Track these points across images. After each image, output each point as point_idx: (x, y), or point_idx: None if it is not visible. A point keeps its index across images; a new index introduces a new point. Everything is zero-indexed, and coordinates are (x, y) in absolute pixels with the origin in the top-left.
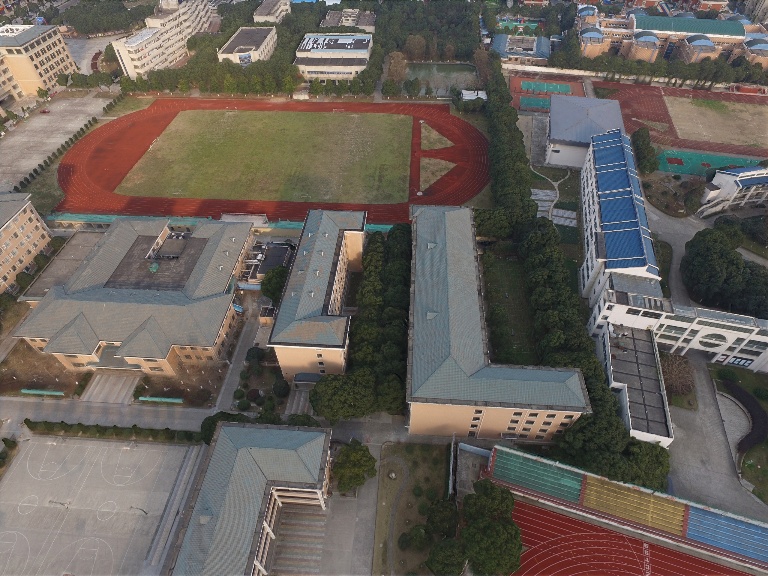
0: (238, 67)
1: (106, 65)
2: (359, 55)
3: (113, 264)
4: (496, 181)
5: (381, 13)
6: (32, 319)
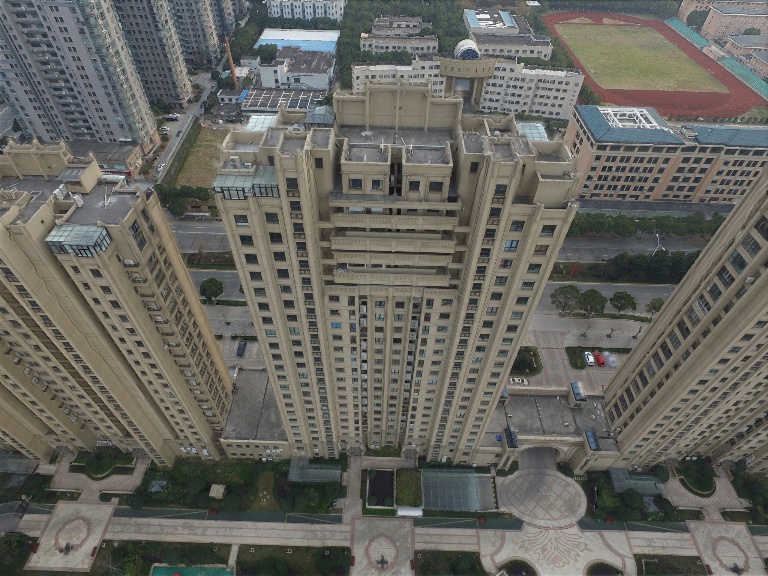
0: None
1: None
2: None
3: None
4: (634, 2)
5: None
6: None
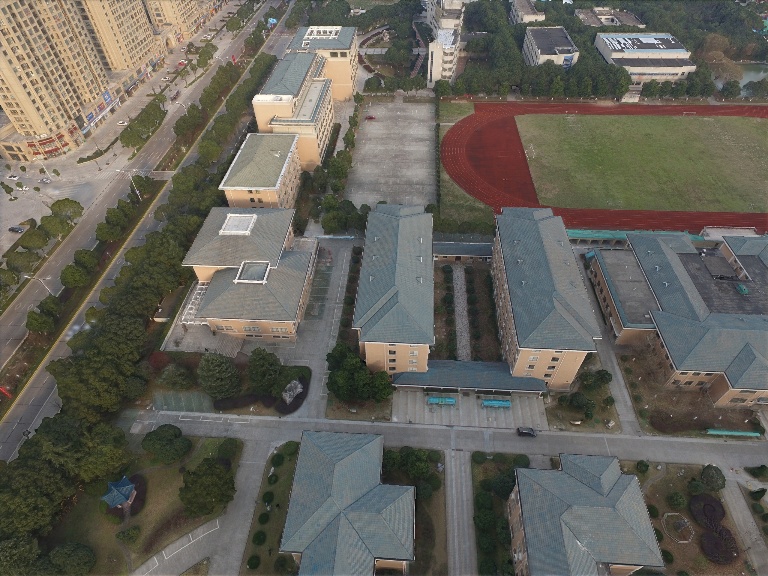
0: (563, 69)
1: (380, 68)
2: (681, 55)
3: (692, 286)
4: None
5: (638, 11)
6: (693, 350)
